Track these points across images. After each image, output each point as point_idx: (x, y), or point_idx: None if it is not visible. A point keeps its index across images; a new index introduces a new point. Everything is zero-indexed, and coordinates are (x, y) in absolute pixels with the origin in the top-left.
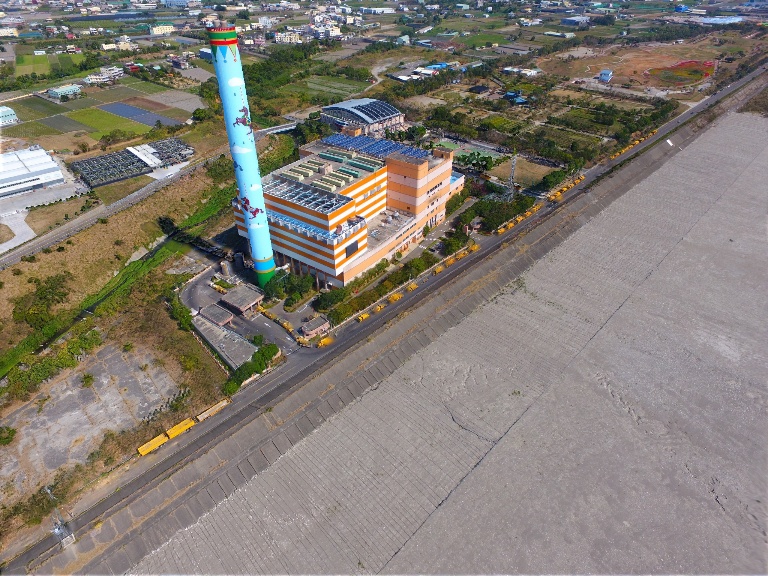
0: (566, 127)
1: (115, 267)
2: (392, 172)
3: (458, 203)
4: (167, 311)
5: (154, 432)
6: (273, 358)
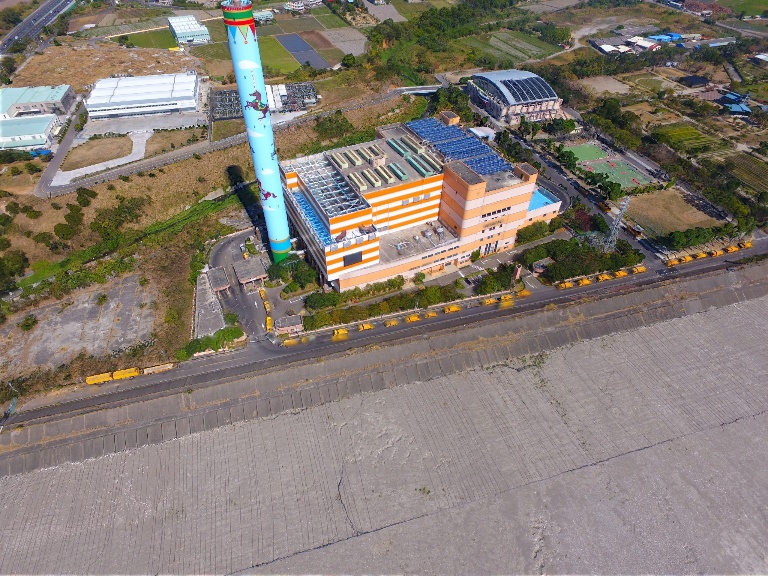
0: None
1: (189, 202)
2: (447, 182)
3: (541, 232)
4: None
5: (109, 367)
6: (236, 340)
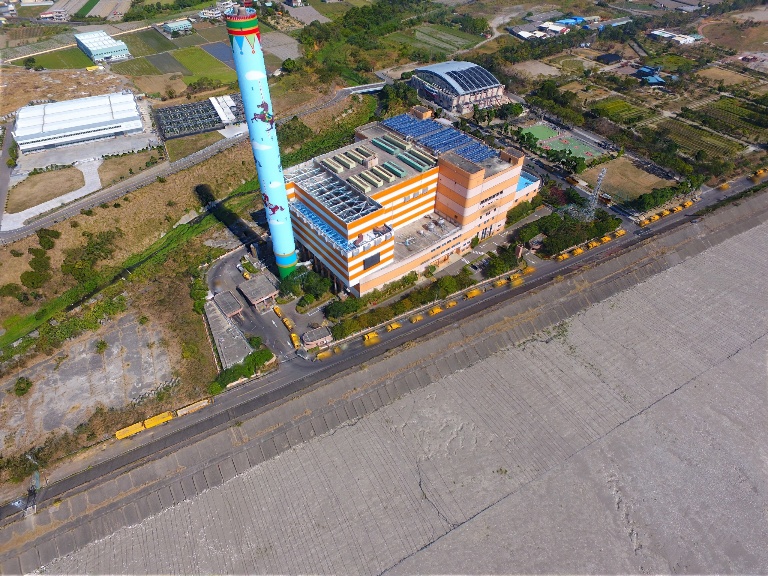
0: (703, 124)
1: (163, 228)
2: (443, 174)
3: (526, 211)
4: (190, 287)
5: (136, 417)
6: (266, 363)
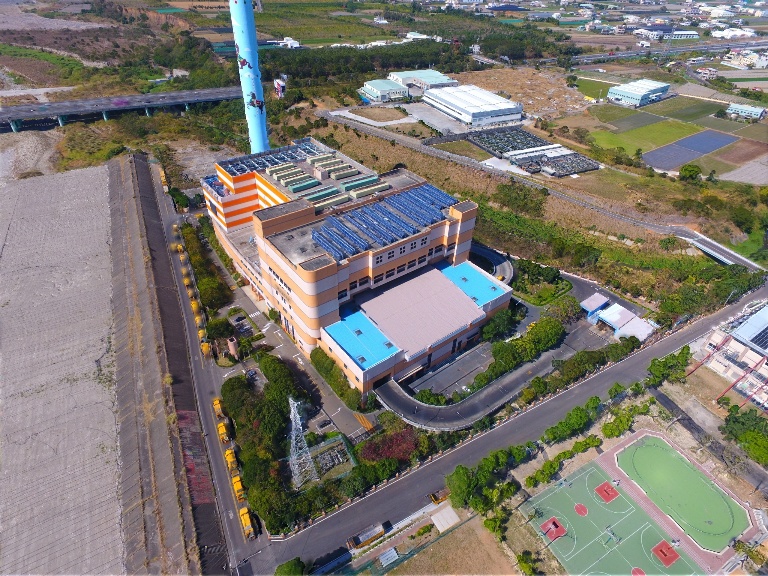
0: None
1: None
2: None
3: None
4: None
5: None
6: None
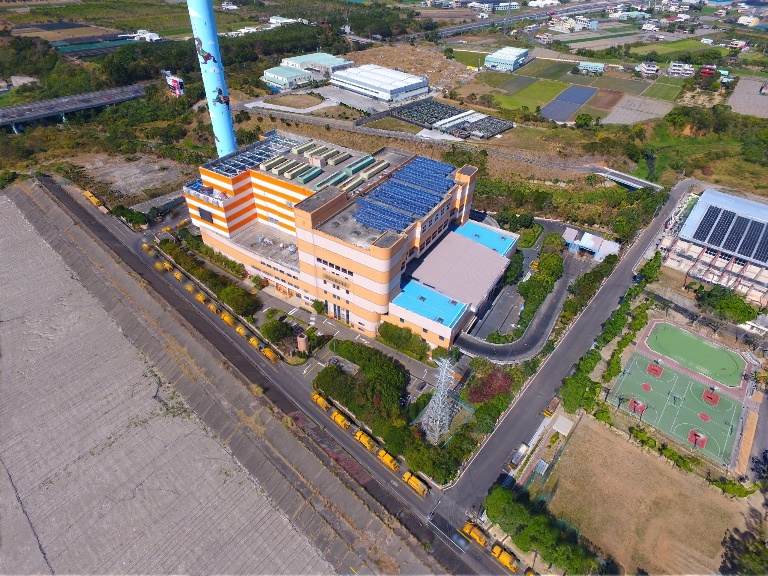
0: None
1: None
2: None
3: None
4: None
5: None
6: None
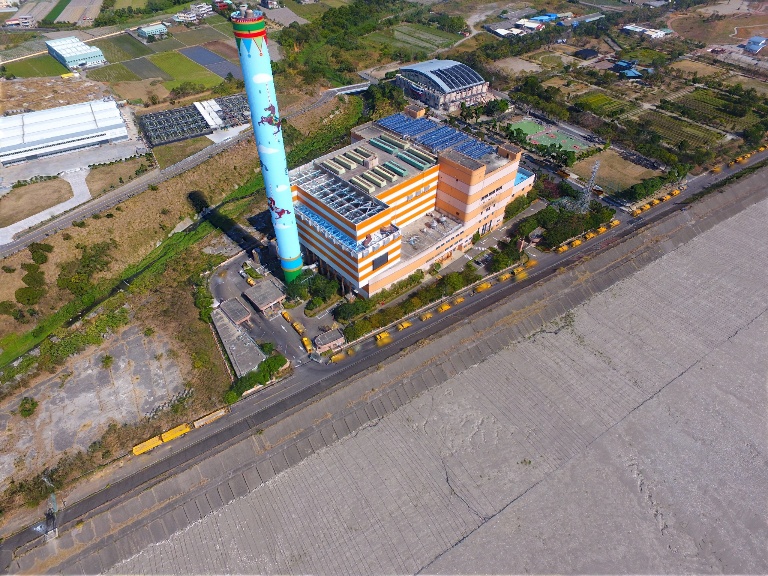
0: (682, 115)
1: (158, 237)
2: (444, 172)
3: (522, 206)
4: (193, 296)
5: (152, 431)
6: (280, 369)
